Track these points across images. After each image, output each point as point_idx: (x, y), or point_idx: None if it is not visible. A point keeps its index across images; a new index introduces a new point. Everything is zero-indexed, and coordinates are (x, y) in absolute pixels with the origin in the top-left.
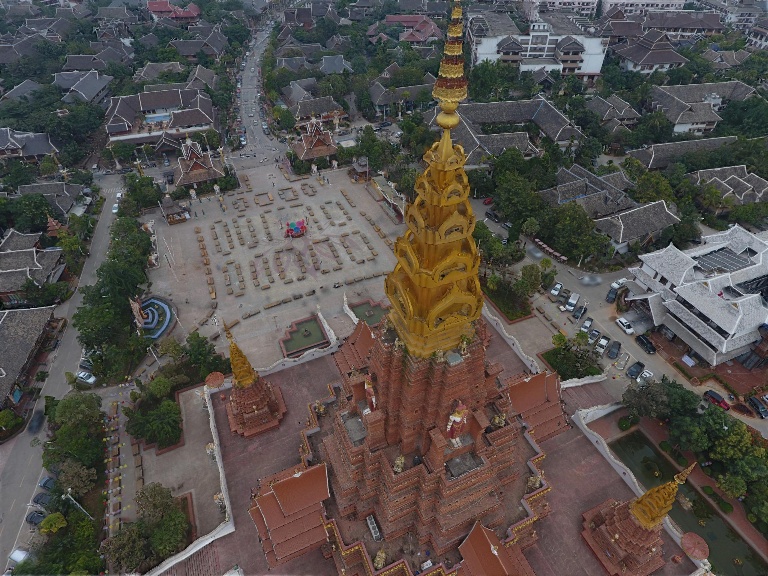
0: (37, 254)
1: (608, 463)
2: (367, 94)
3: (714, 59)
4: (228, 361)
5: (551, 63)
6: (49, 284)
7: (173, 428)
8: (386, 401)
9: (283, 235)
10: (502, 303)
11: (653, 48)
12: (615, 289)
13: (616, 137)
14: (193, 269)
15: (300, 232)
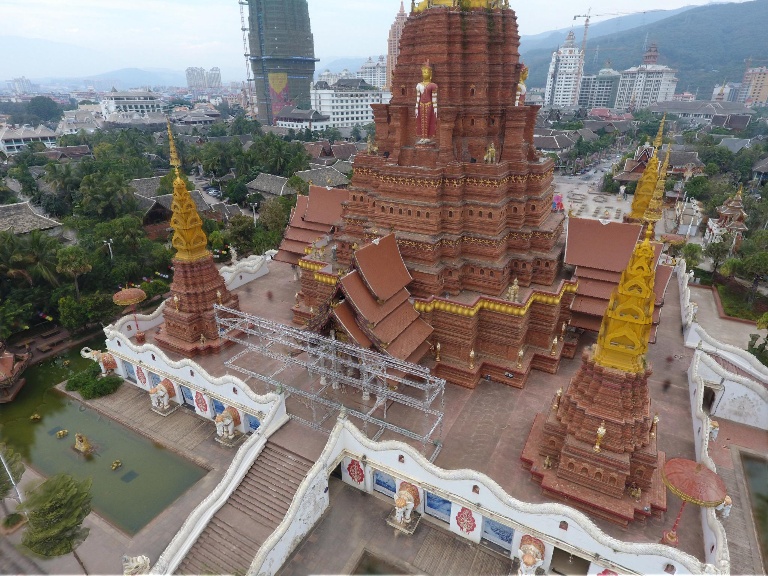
0: None
1: (690, 422)
2: (749, 161)
3: None
4: None
5: None
6: None
7: None
8: None
9: None
10: (733, 301)
11: None
12: None
13: None
14: None
15: (555, 208)
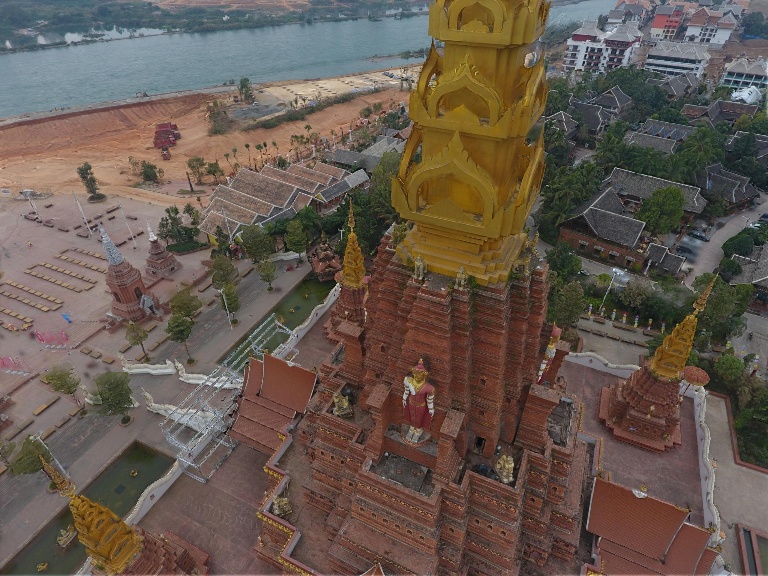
0: None
1: None
2: None
3: None
4: (760, 450)
5: None
6: None
7: None
8: None
9: None
10: None
11: None
12: None
13: None
14: None
15: None
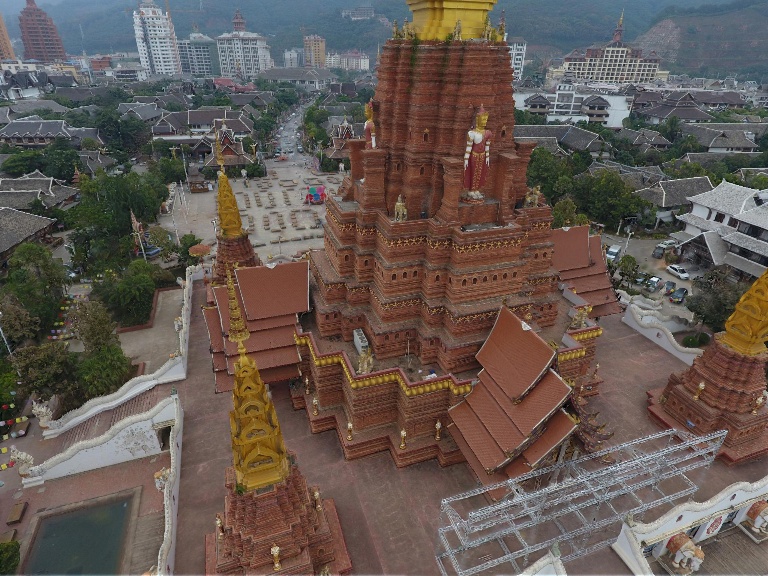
0: (53, 185)
1: (675, 357)
2: None
3: (740, 120)
4: None
5: (577, 116)
6: (56, 208)
7: (142, 296)
8: (389, 140)
9: (302, 202)
10: None
11: (677, 105)
12: (662, 247)
13: (648, 155)
14: (205, 217)
15: (320, 200)
